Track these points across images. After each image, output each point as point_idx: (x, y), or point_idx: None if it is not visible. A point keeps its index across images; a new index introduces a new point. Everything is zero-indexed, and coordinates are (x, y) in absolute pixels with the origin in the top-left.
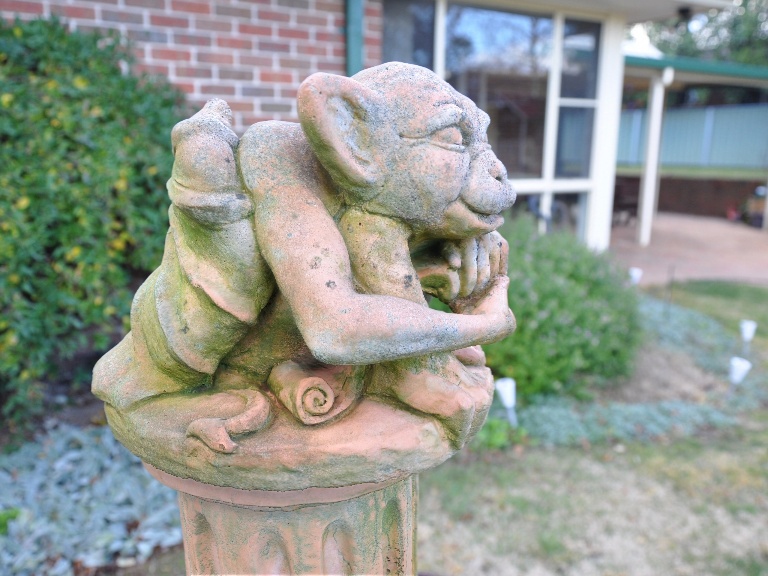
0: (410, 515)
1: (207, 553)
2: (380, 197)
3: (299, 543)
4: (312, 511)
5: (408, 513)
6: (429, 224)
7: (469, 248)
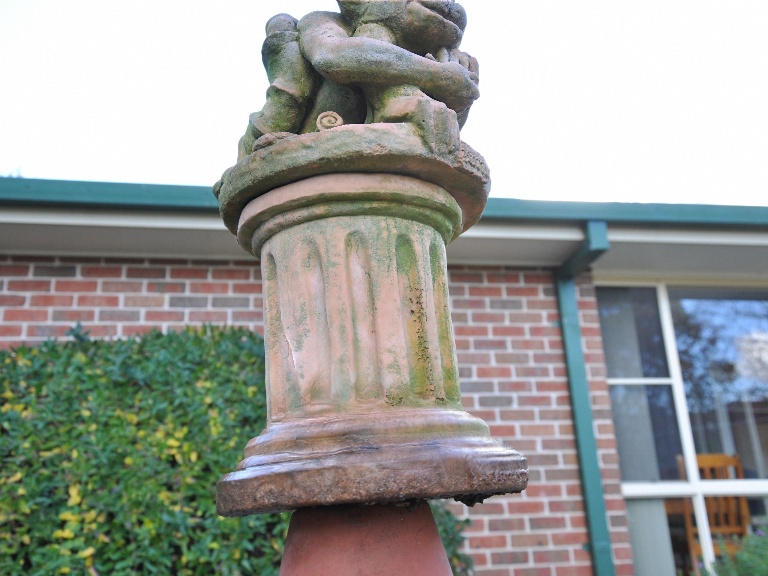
0: (428, 268)
1: (275, 296)
2: (368, 10)
3: (327, 245)
4: (337, 221)
5: (425, 263)
6: (400, 21)
7: (442, 55)
